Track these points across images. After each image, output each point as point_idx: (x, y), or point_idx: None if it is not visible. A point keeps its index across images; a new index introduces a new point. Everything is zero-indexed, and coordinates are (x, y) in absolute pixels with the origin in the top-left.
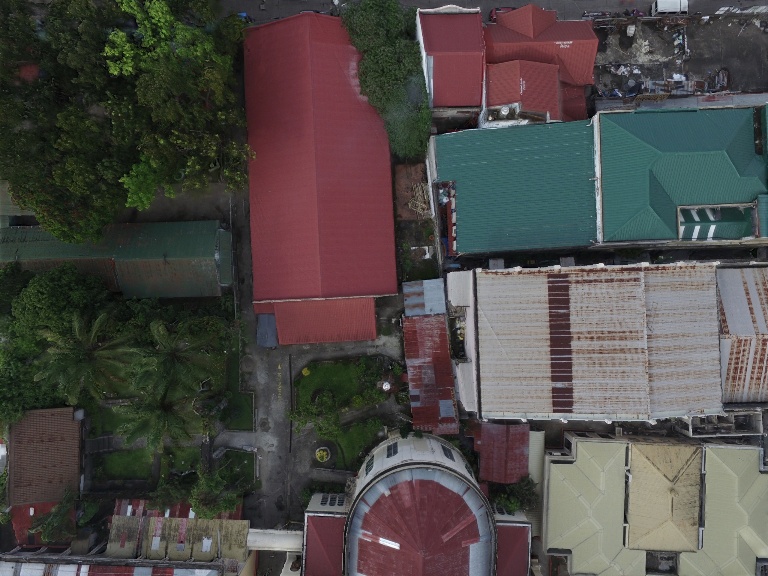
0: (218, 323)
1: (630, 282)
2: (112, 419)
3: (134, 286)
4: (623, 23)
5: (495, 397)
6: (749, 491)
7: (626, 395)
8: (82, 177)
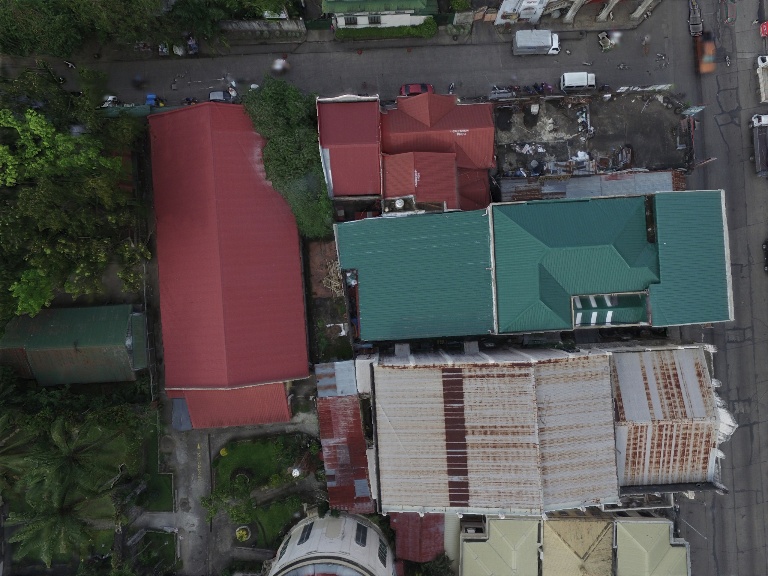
0: (127, 414)
1: (521, 377)
2: None
3: (47, 374)
4: (526, 103)
5: (394, 490)
6: (659, 565)
7: (519, 489)
8: None
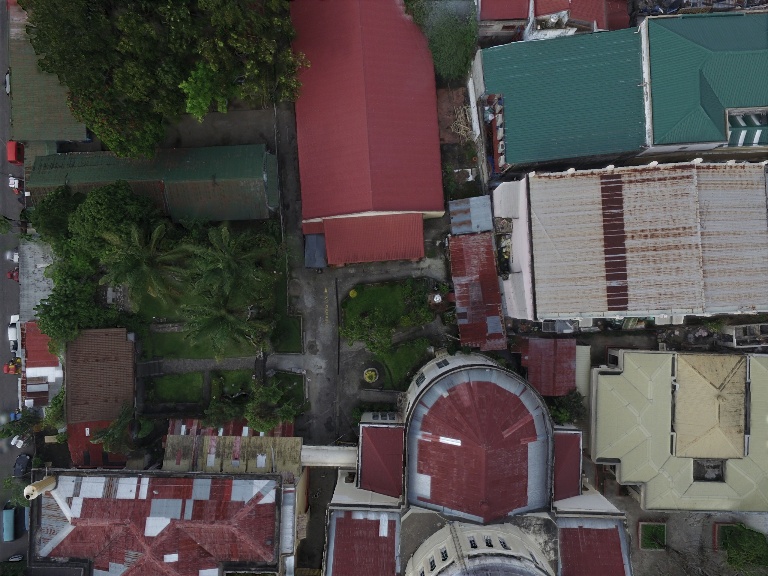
0: (270, 240)
1: (683, 179)
2: (162, 344)
3: (183, 209)
4: None
5: (550, 298)
6: None
7: (681, 290)
8: (143, 81)
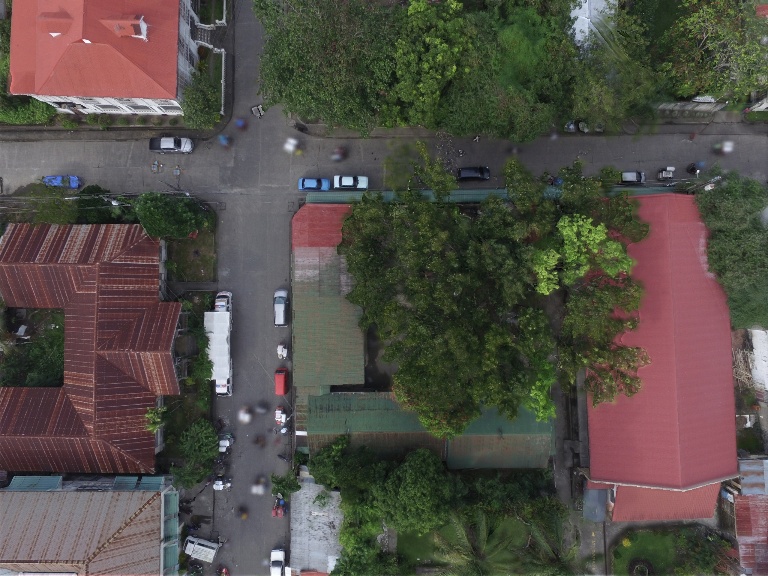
0: None
1: None
2: None
3: (462, 458)
4: None
5: None
6: None
7: None
8: (502, 395)
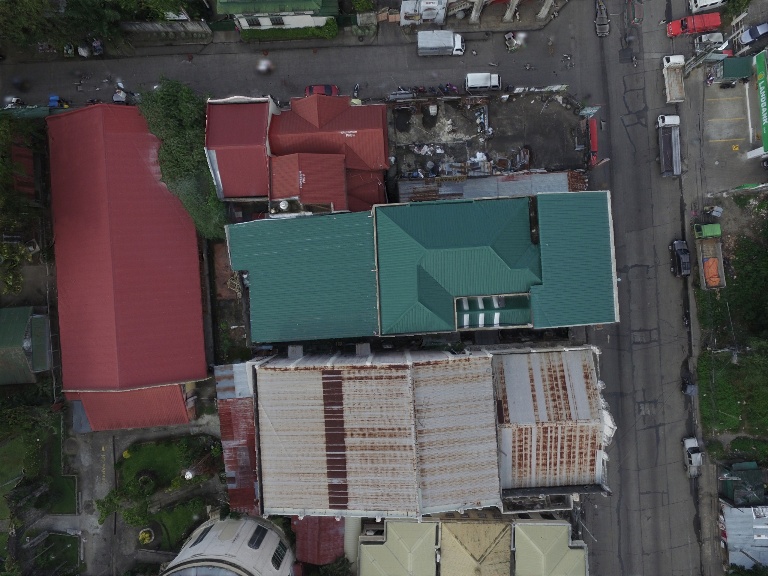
0: (20, 416)
1: (398, 379)
2: None
3: None
4: (423, 104)
5: (276, 493)
6: (557, 568)
7: (396, 492)
8: None
